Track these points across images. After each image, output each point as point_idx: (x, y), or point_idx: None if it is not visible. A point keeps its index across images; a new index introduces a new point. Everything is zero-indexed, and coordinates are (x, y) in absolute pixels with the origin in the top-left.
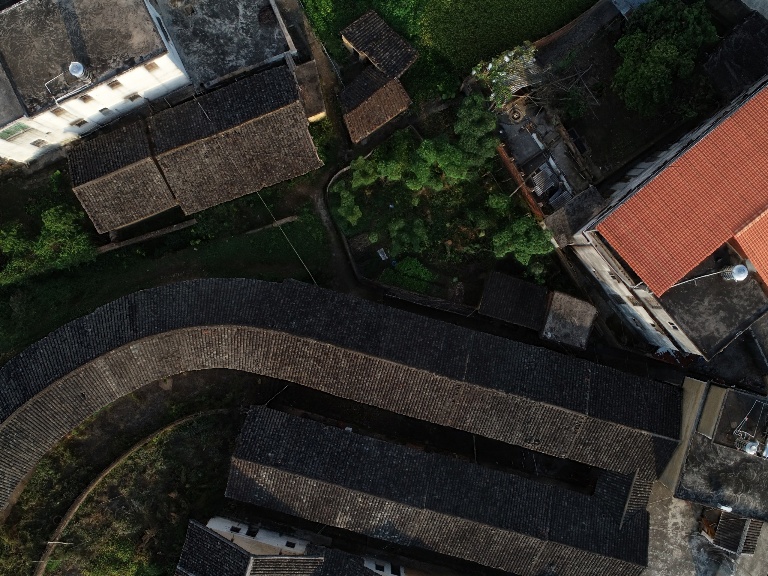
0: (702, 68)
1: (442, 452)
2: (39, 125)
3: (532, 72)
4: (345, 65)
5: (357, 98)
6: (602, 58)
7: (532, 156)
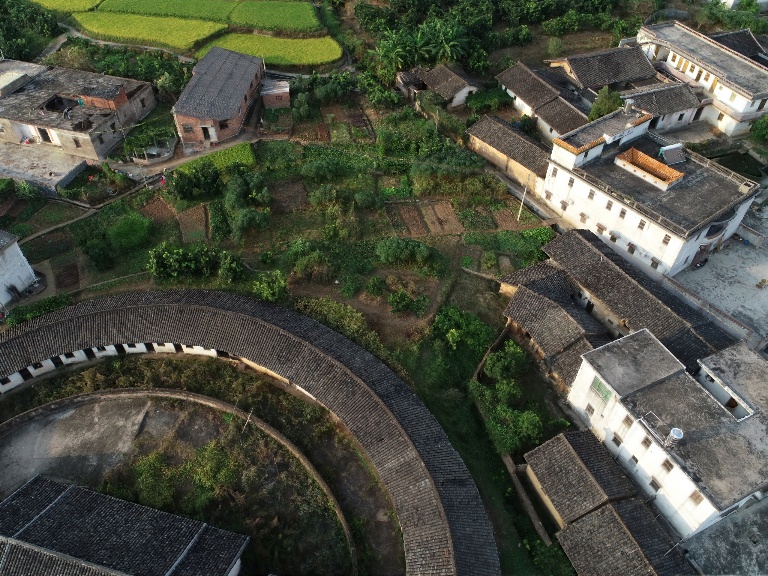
0: None
1: None
2: (611, 408)
3: None
4: None
5: None
6: None
7: None
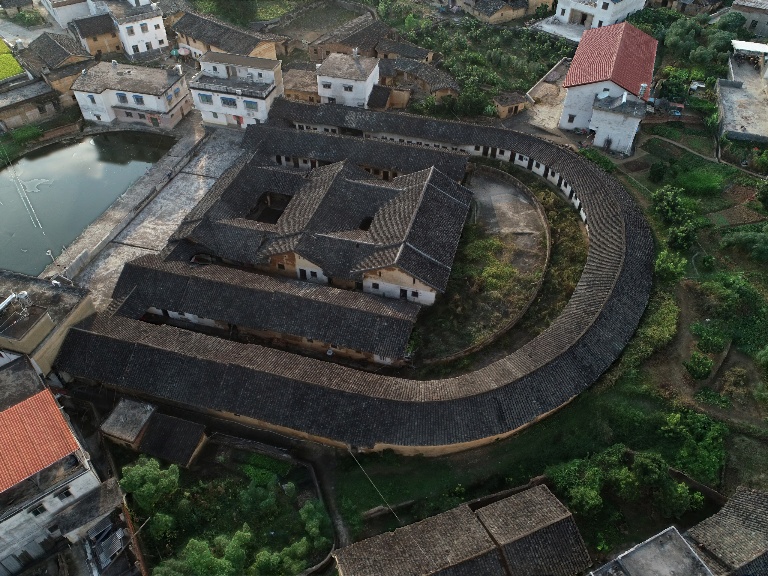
0: None
1: (259, 342)
2: None
3: None
4: None
5: None
6: None
7: None
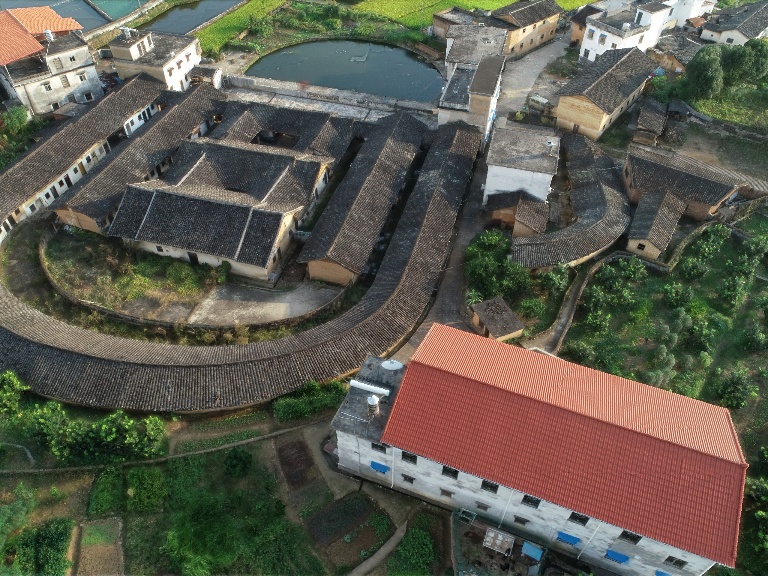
0: None
1: None
2: None
3: None
4: None
5: None
6: None
7: None
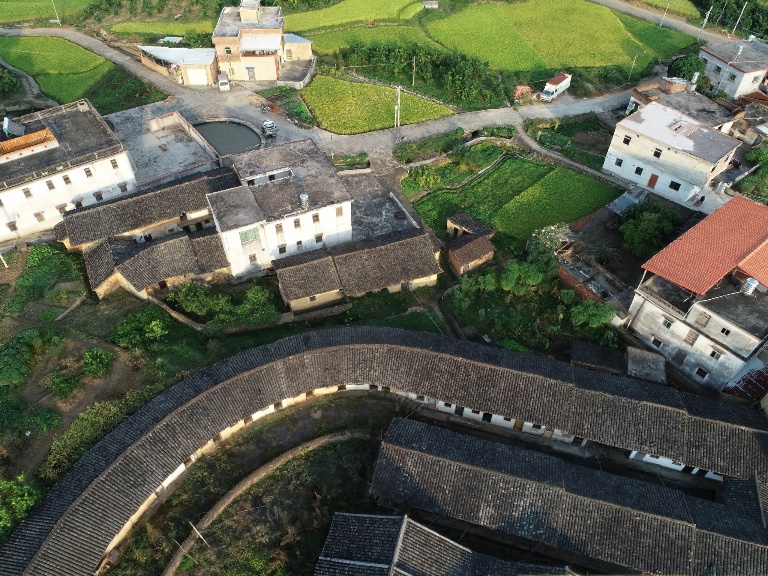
0: (678, 233)
1: None
2: (264, 237)
3: (571, 235)
4: (448, 242)
5: (461, 245)
6: (613, 240)
7: (583, 281)
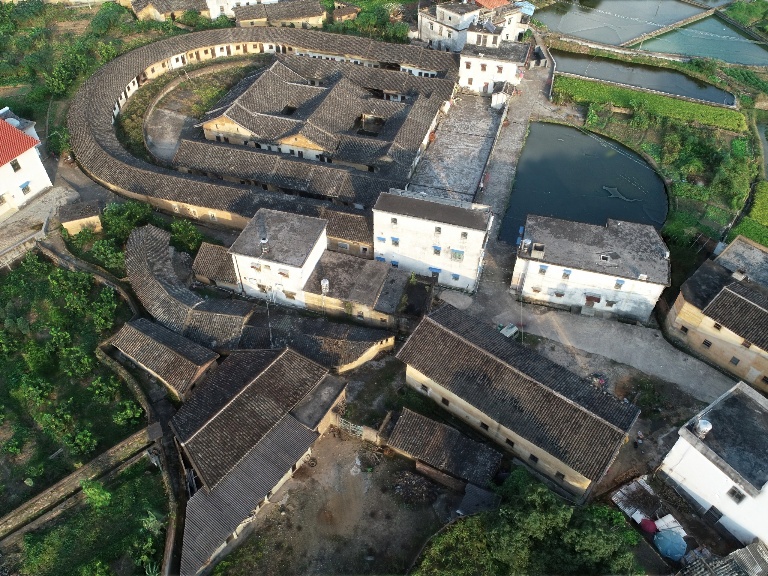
0: None
1: None
2: None
3: (401, 7)
4: None
5: None
6: None
7: None
